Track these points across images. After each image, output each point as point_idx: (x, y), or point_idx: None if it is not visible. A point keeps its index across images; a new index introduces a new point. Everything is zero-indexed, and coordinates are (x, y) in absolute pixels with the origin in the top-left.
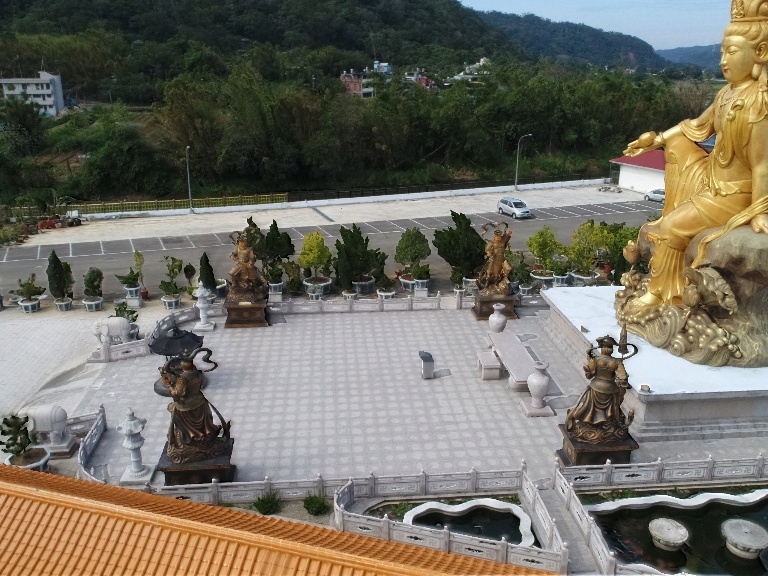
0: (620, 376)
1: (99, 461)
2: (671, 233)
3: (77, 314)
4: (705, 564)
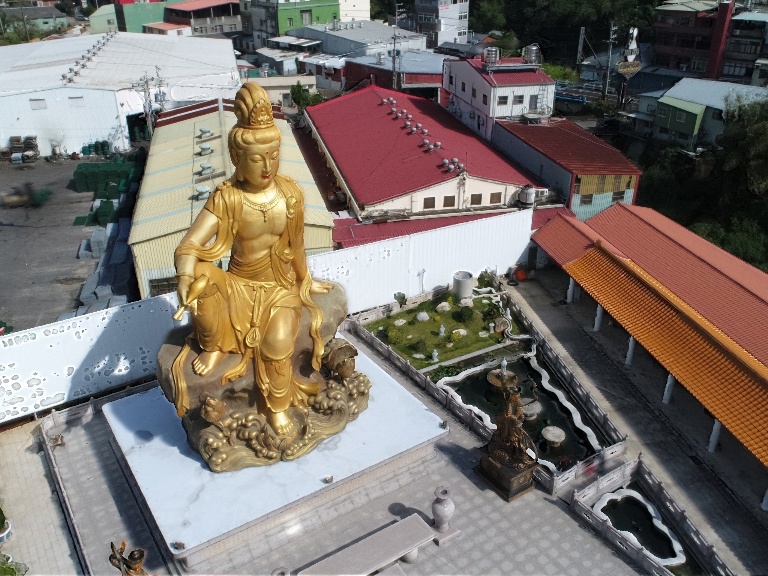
0: None
1: None
2: None
3: None
4: None
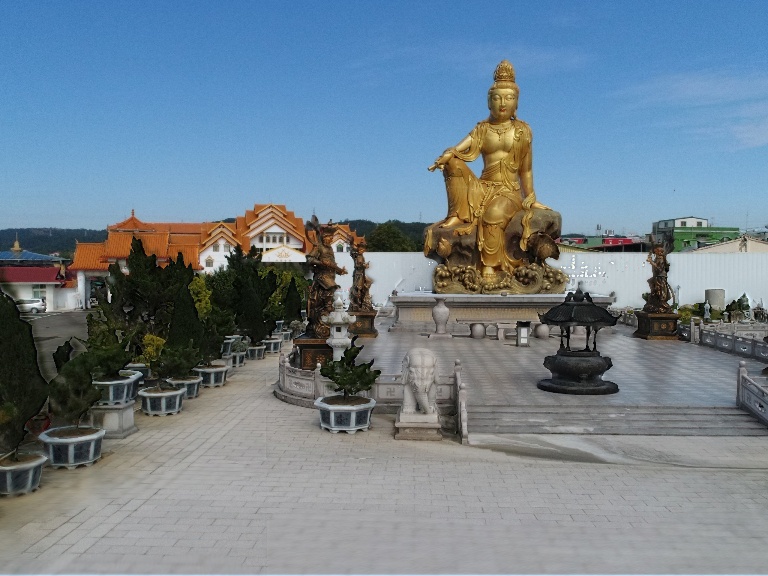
0: None
1: None
2: None
3: (99, 473)
4: None
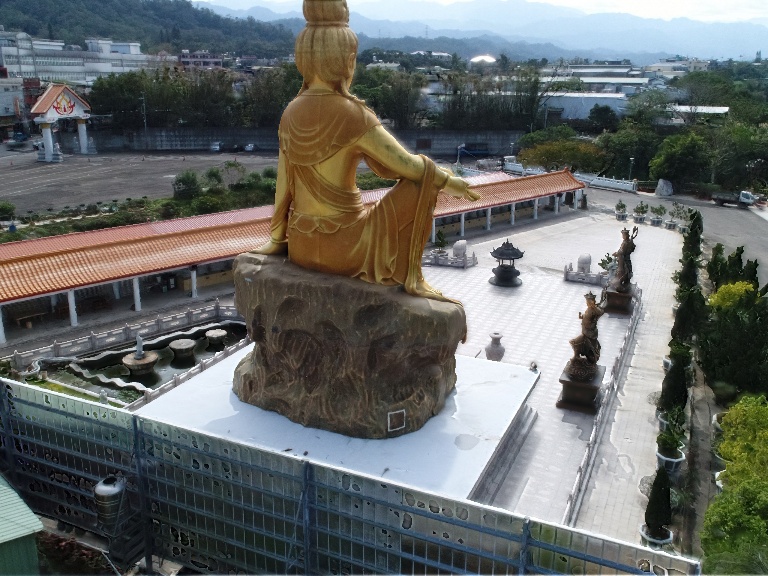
0: None
1: (435, 266)
2: None
3: None
4: (199, 355)
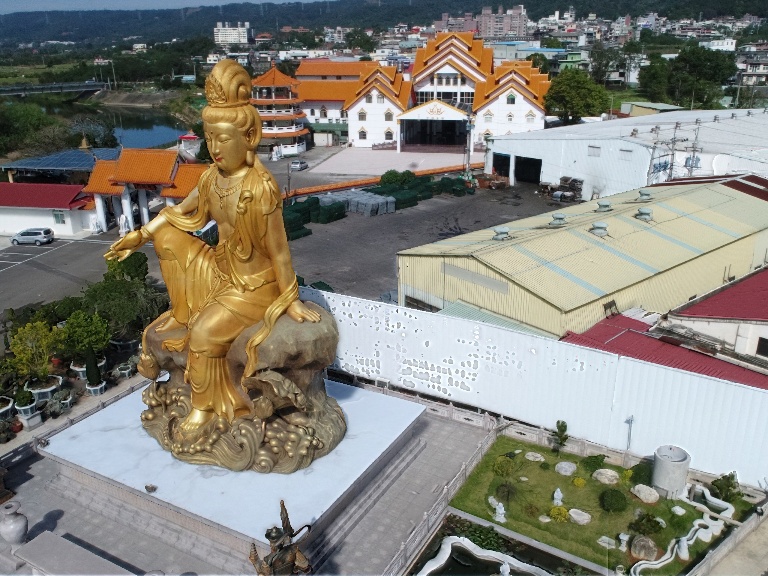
0: (302, 565)
1: None
2: (210, 344)
3: None
4: None
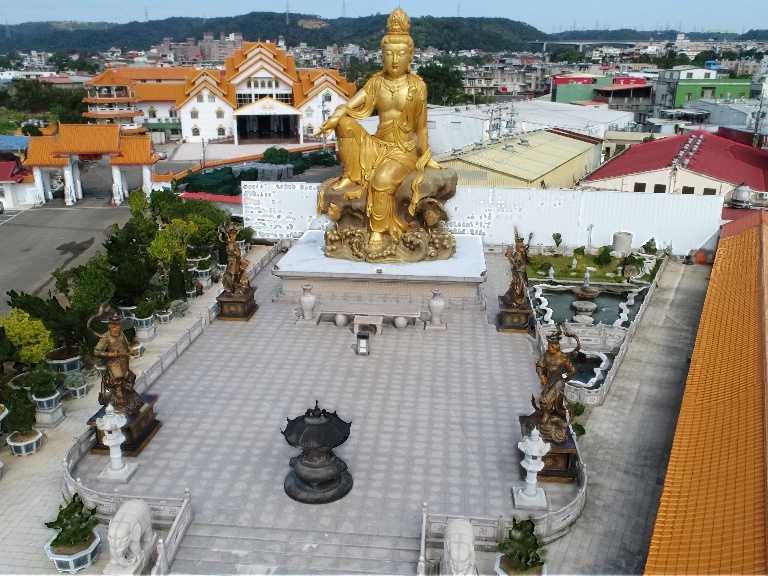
0: (530, 256)
1: None
2: (392, 184)
3: None
4: None
